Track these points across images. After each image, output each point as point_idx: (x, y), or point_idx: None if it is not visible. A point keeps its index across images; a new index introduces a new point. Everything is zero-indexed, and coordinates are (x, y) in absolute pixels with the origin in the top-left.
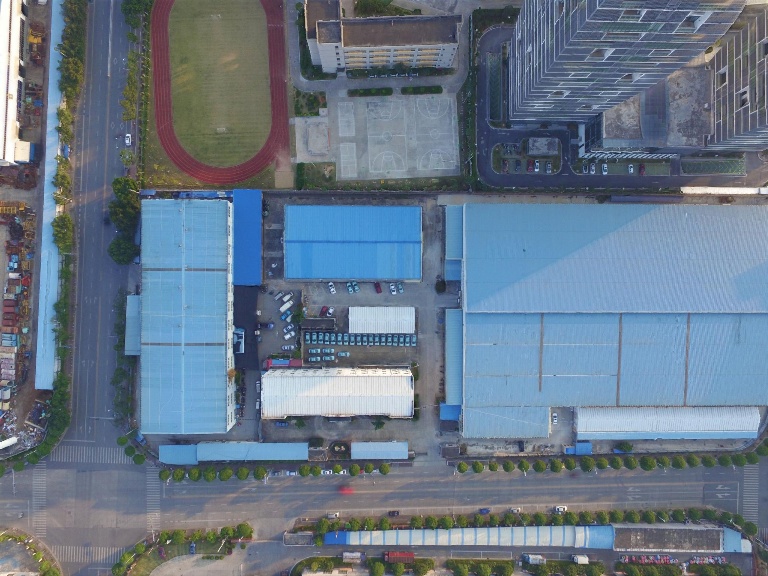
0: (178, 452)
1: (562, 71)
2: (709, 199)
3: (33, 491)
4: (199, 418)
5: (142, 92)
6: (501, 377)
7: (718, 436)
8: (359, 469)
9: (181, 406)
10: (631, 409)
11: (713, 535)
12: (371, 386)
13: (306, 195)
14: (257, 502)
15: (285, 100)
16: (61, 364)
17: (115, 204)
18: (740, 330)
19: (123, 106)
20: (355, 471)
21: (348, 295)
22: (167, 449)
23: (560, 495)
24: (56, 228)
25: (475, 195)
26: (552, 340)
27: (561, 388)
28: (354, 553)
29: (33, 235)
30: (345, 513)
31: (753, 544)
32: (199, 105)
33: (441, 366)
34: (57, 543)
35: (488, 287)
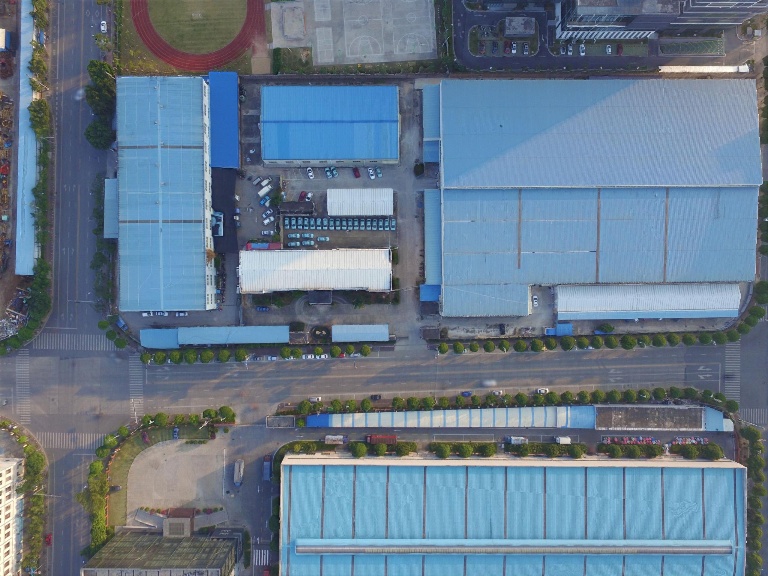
0: (159, 336)
1: None
2: None
3: (16, 378)
4: (178, 295)
5: None
6: (480, 254)
7: (699, 315)
8: (340, 351)
9: (160, 283)
10: (611, 288)
11: (695, 413)
12: (349, 260)
13: (283, 80)
14: (239, 387)
15: None
16: (41, 252)
17: (91, 87)
18: (719, 205)
19: None
20: (336, 352)
21: (327, 180)
22: (148, 333)
23: (542, 378)
24: (33, 112)
25: (452, 78)
26: (530, 216)
27: (540, 265)
28: (337, 436)
29: (11, 124)
30: (327, 398)
31: (735, 424)
32: None
33: (421, 250)
34: (41, 430)
35: (465, 163)
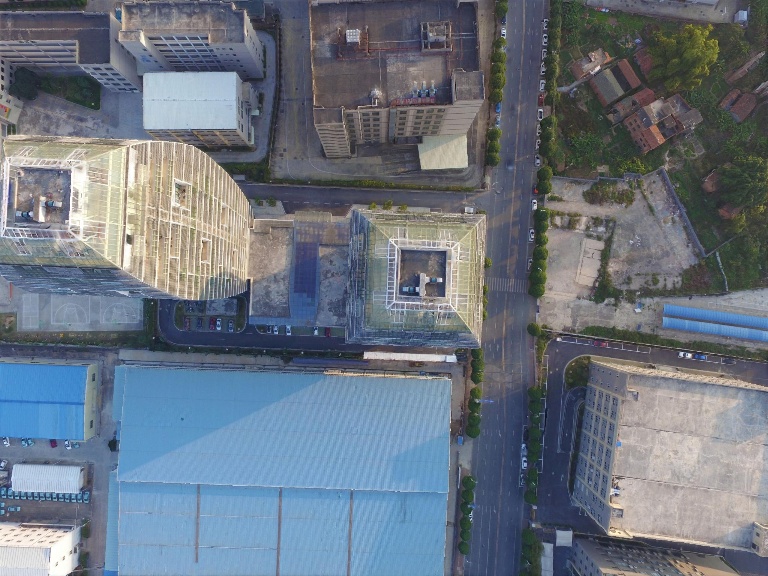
0: None
1: None
2: (399, 362)
3: None
4: None
5: None
6: (156, 546)
7: None
8: None
9: None
10: None
11: None
12: (8, 557)
13: None
14: None
15: None
16: None
17: None
18: (406, 508)
19: None
20: None
21: (23, 448)
22: None
23: None
24: None
25: (156, 351)
26: (209, 511)
27: (218, 560)
28: None
29: None
30: None
31: None
32: None
33: None
34: None
35: (142, 456)
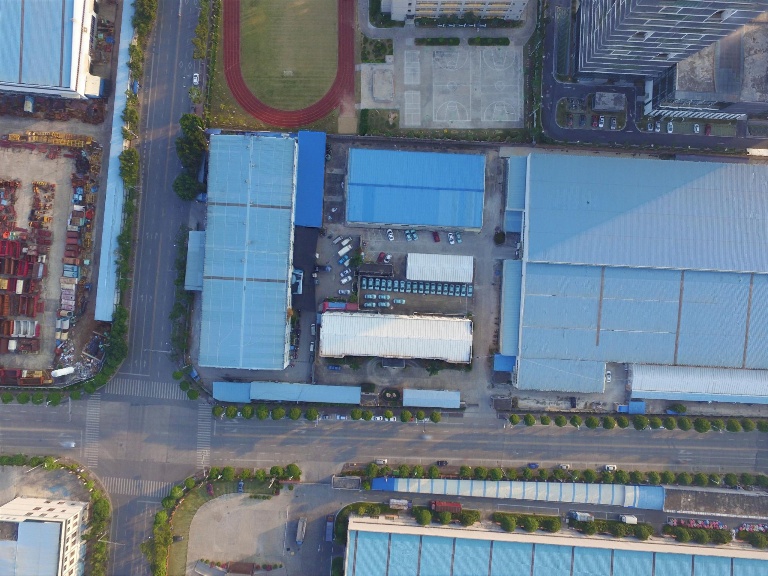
0: (232, 389)
1: (654, 4)
2: None
3: (87, 422)
4: (257, 353)
5: (212, 32)
6: (559, 329)
7: None
8: (411, 415)
9: (240, 340)
10: (687, 370)
11: (765, 502)
12: (430, 329)
13: (369, 141)
14: (306, 445)
15: (352, 46)
16: (120, 297)
17: (182, 140)
18: None
19: (194, 44)
20: (407, 417)
21: (406, 243)
22: (221, 386)
23: (610, 454)
24: (123, 161)
25: (538, 148)
26: (612, 294)
27: (619, 343)
28: (401, 500)
29: (98, 169)
30: (393, 460)
31: None
32: (267, 48)
33: (496, 318)
34: (108, 474)
35: (550, 237)
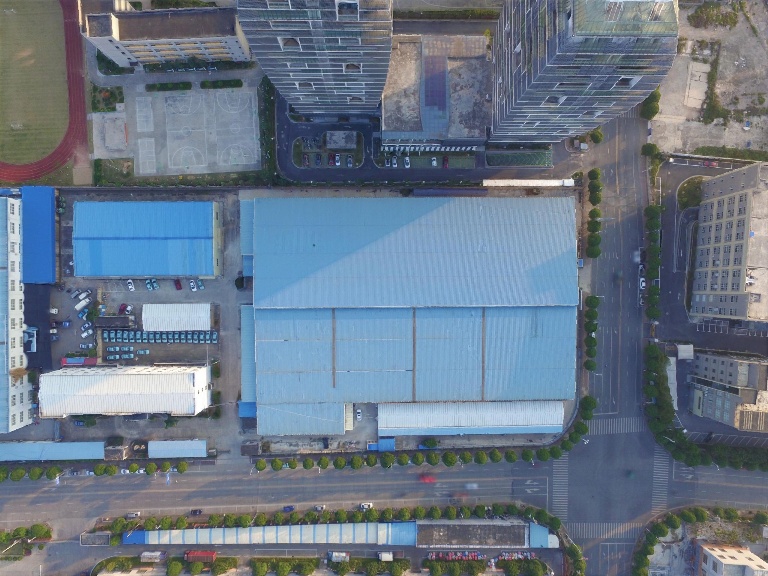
0: None
1: (274, 61)
2: (516, 192)
3: None
4: None
5: None
6: (294, 373)
7: (522, 431)
8: (155, 468)
9: None
10: (433, 404)
11: (518, 531)
12: (152, 384)
13: (104, 191)
14: (57, 502)
15: (83, 95)
16: None
17: None
18: (537, 324)
19: None
20: (149, 470)
21: (148, 292)
22: None
23: (366, 492)
24: None
25: (276, 190)
26: (344, 336)
27: (355, 384)
28: (154, 552)
29: None
30: (147, 512)
31: (562, 539)
32: None
33: None
34: None
35: (276, 283)
